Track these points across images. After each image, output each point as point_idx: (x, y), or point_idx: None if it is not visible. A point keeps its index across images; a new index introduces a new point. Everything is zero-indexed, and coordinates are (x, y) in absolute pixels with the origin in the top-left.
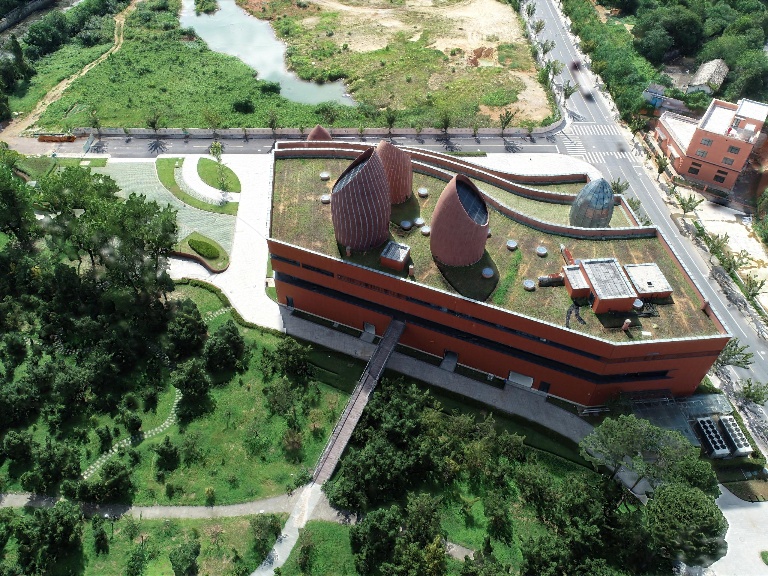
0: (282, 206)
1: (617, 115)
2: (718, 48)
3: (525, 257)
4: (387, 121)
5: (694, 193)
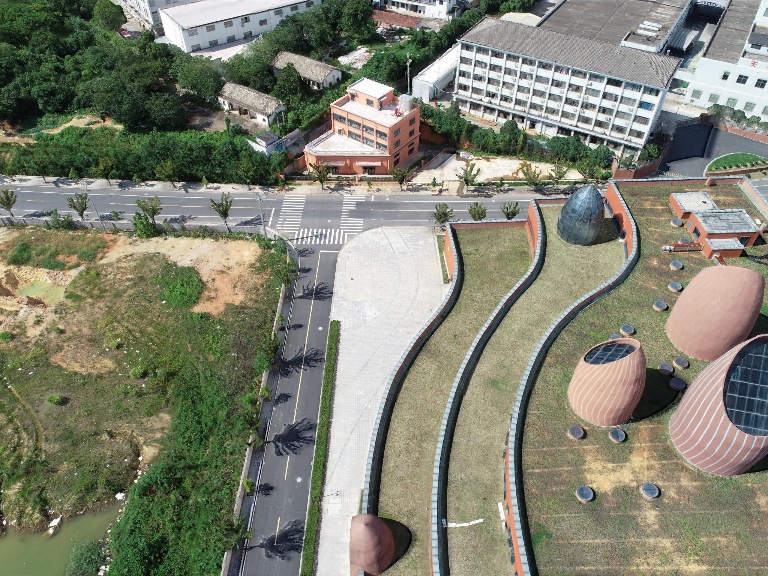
0: (690, 567)
1: (263, 188)
2: (213, 76)
3: (689, 280)
4: (256, 432)
5: (424, 174)
